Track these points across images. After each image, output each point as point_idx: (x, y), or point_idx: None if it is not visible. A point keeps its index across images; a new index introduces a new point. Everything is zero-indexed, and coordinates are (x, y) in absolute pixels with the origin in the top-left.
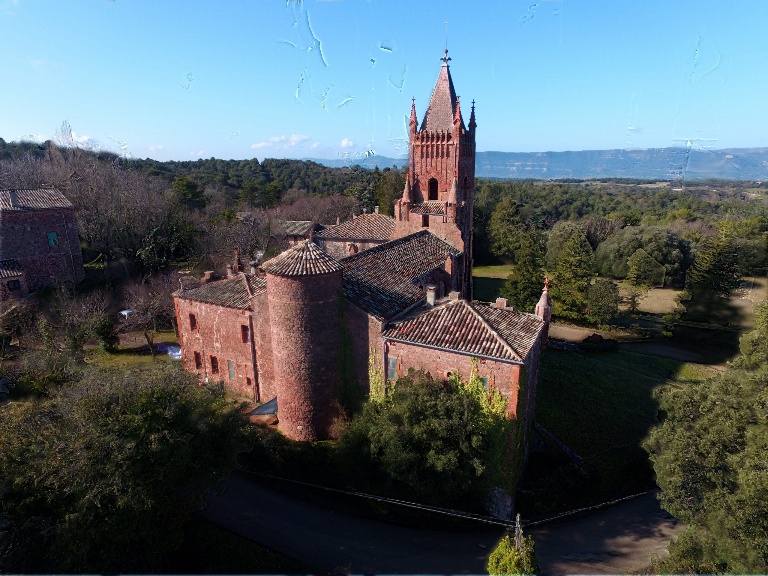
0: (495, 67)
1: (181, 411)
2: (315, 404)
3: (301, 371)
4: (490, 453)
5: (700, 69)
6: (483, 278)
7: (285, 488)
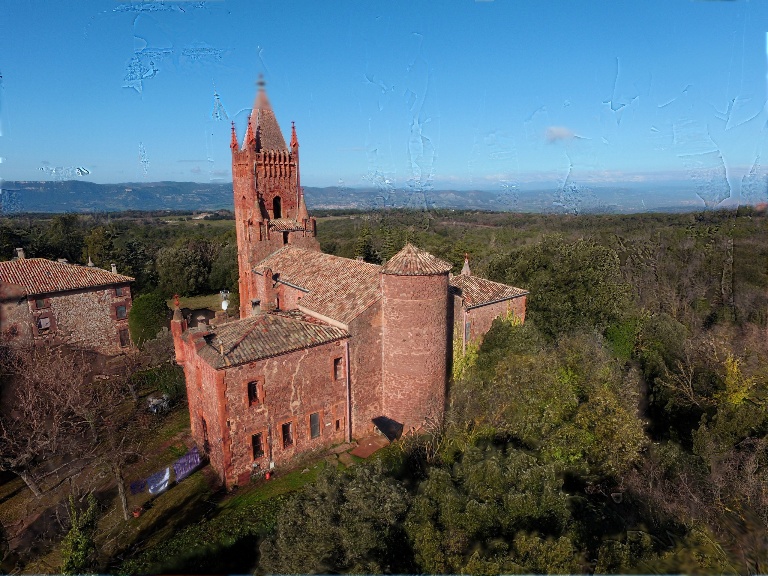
0: (556, 125)
1: None
2: None
3: None
4: None
5: (313, 122)
6: None
7: None
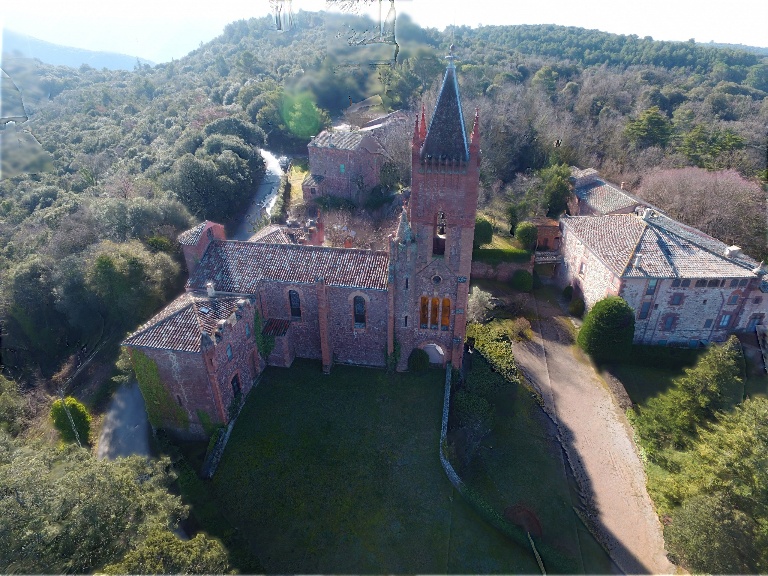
0: None
1: None
2: None
3: None
4: None
5: None
6: None
7: None
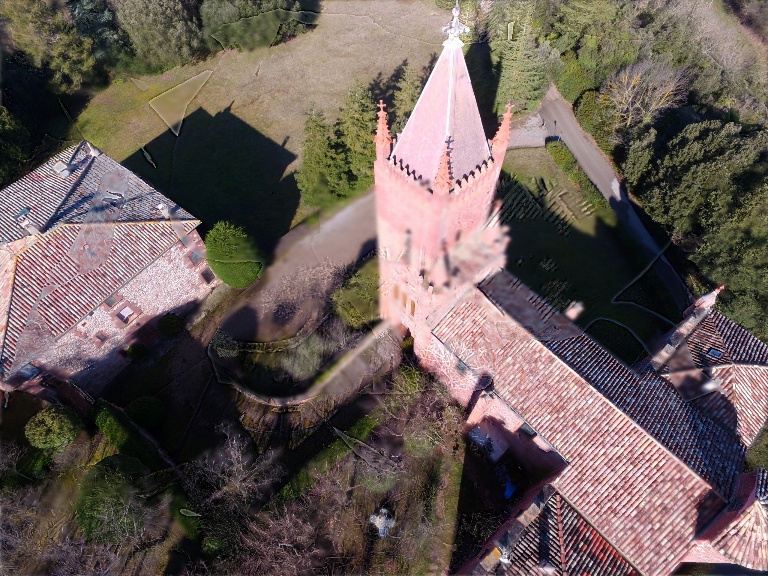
0: None
1: None
2: None
3: None
4: None
5: None
6: (141, 155)
7: None
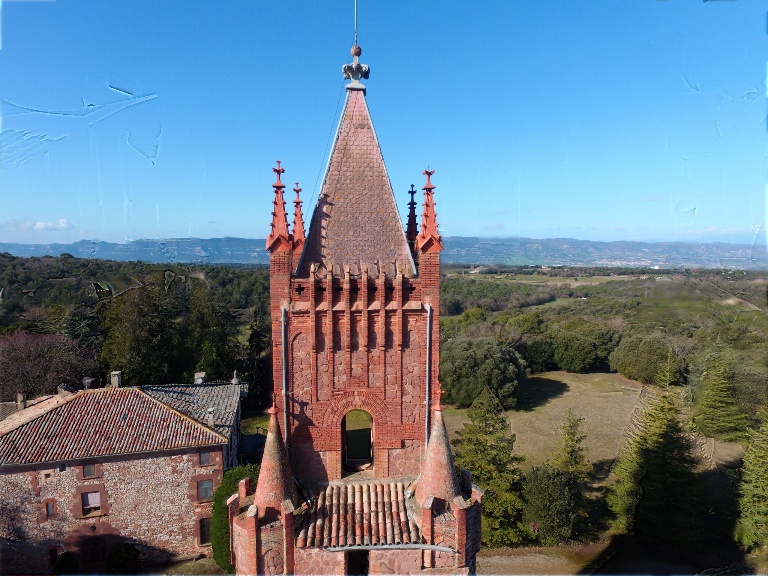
0: None
1: None
2: None
3: None
4: None
5: (574, 171)
6: None
7: None
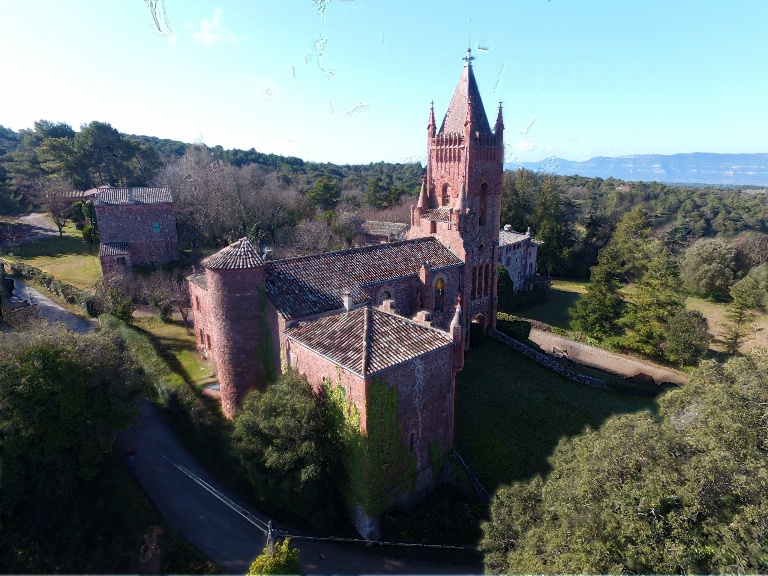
0: None
1: (66, 367)
2: (238, 387)
3: (225, 355)
4: (352, 466)
5: None
6: None
7: (201, 456)
